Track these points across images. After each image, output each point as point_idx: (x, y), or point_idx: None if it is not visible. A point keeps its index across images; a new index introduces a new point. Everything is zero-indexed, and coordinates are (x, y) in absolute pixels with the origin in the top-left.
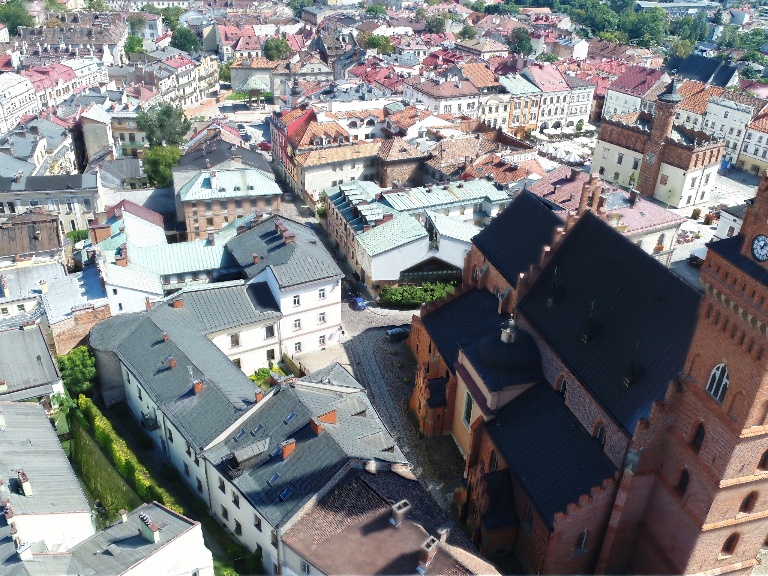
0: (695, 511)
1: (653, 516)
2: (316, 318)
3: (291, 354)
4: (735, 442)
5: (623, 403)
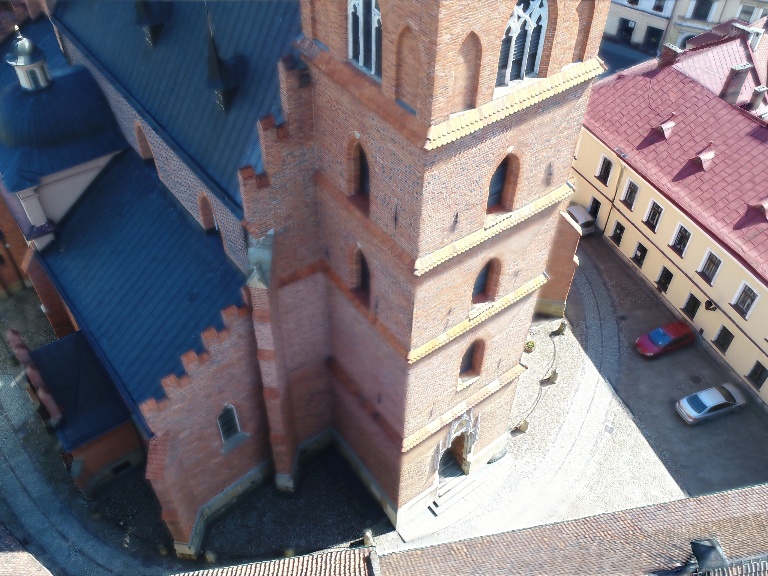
0: (392, 329)
1: (341, 346)
2: None
3: None
4: (421, 165)
5: (221, 146)
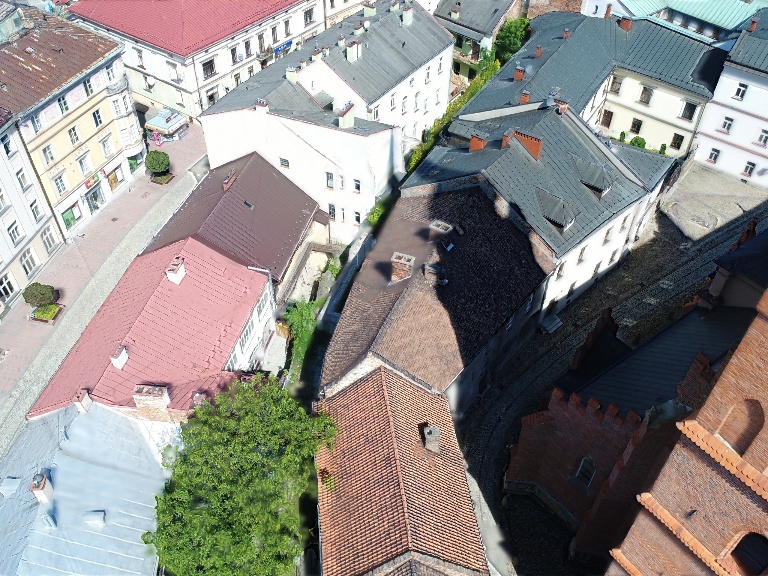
0: None
1: None
2: (755, 132)
3: (701, 158)
4: None
5: None
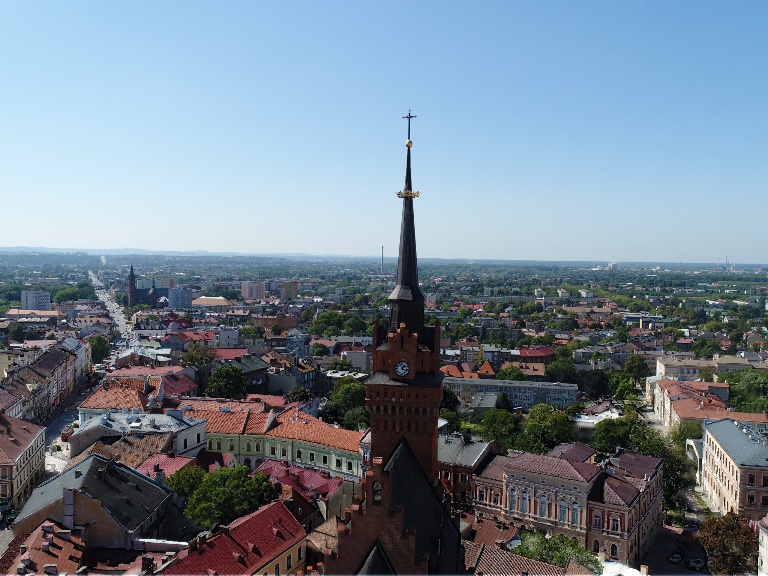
0: None
1: None
2: None
3: None
4: None
5: None
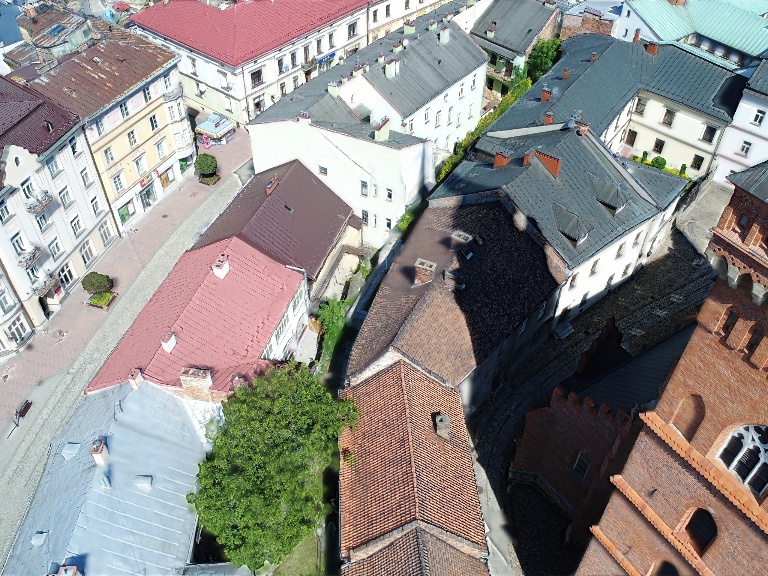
0: None
1: None
2: None
3: (720, 179)
4: None
5: None
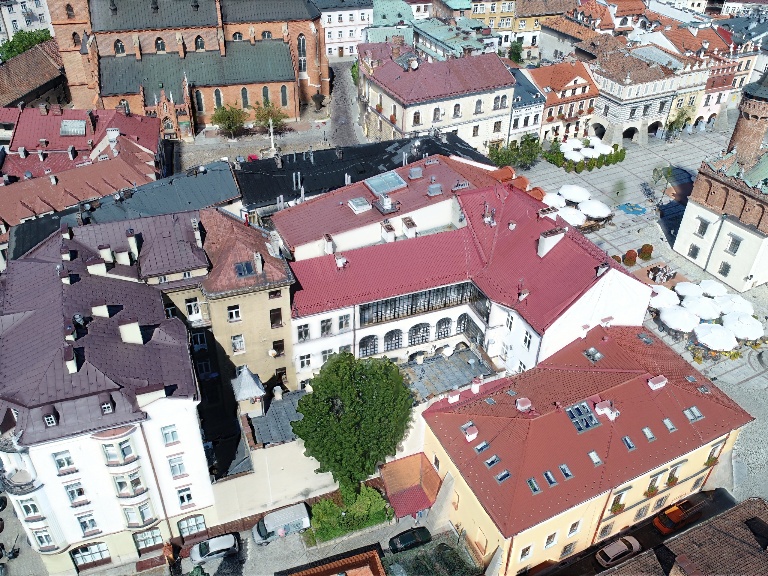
0: None
1: None
2: None
3: None
4: None
5: None
